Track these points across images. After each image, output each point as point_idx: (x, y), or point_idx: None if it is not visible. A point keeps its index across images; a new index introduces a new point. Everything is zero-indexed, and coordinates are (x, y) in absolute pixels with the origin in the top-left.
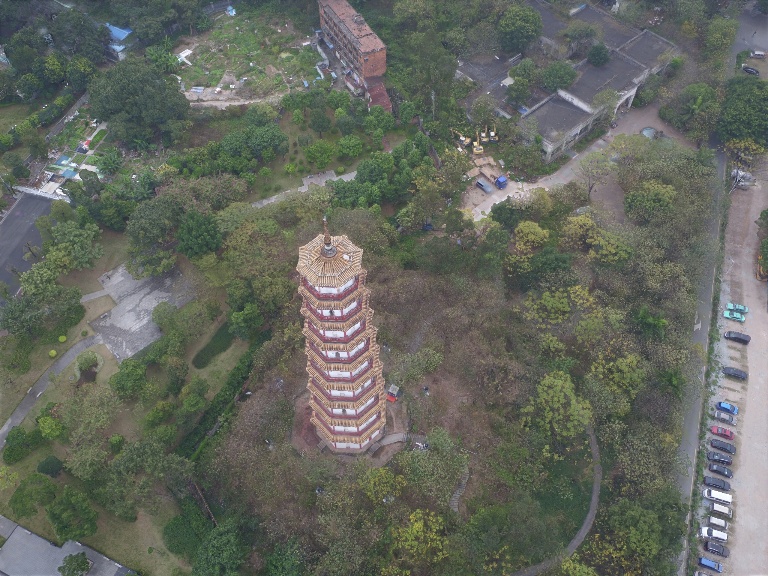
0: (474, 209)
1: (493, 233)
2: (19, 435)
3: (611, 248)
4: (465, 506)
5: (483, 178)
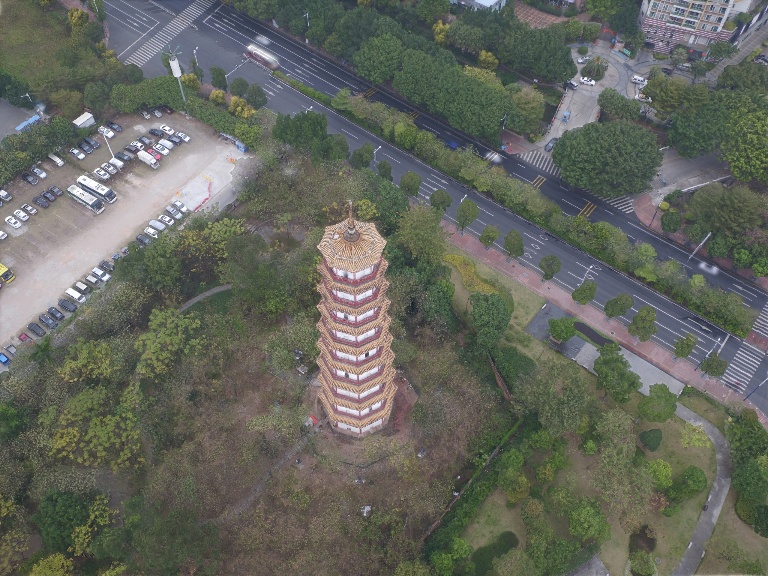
0: None
1: (113, 537)
2: (692, 476)
3: None
4: None
5: None
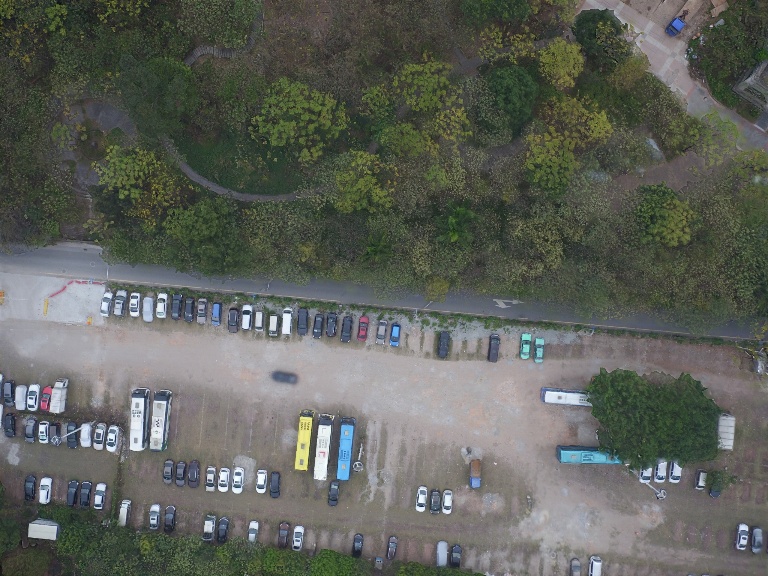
0: (620, 1)
1: None
2: None
3: (544, 157)
4: (204, 61)
5: (682, 3)
